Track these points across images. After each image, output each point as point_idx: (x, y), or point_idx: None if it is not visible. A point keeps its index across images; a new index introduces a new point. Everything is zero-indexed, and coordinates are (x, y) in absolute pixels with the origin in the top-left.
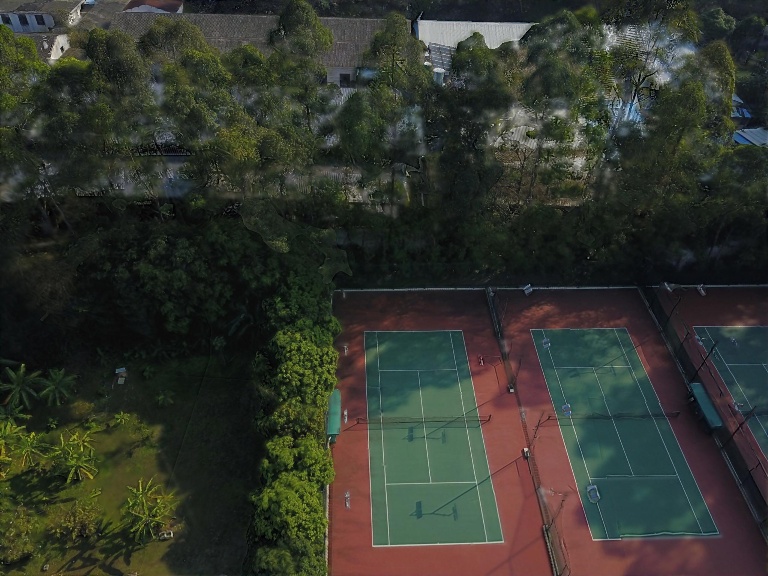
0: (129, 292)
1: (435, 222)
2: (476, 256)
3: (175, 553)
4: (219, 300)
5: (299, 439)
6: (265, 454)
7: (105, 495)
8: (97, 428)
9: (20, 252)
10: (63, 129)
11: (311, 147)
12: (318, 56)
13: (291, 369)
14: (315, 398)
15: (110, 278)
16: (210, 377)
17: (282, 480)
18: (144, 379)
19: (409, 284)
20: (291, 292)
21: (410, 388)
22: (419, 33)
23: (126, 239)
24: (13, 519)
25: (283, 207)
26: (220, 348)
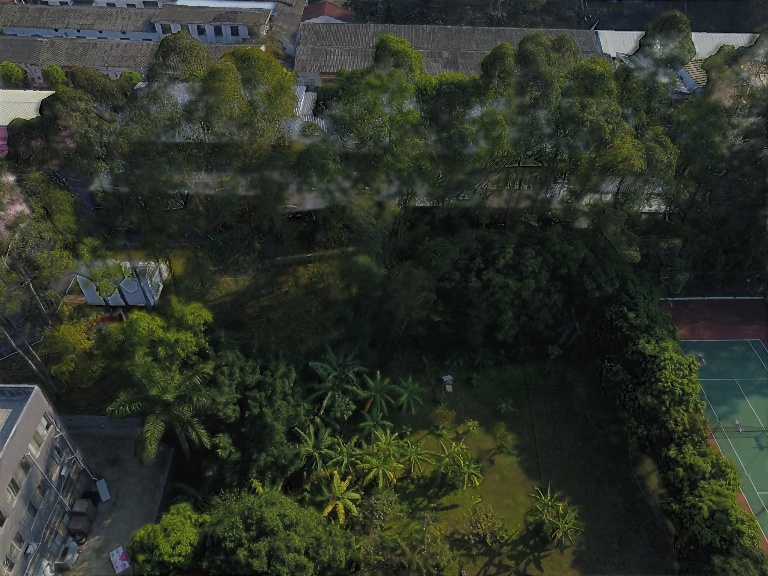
0: (482, 301)
1: (728, 232)
2: (765, 266)
3: (582, 560)
4: (551, 309)
5: (698, 448)
6: (624, 462)
7: (487, 502)
8: (448, 435)
9: (382, 261)
10: (464, 141)
11: (676, 159)
12: (679, 69)
13: (670, 378)
14: (697, 407)
15: (458, 287)
16: (534, 385)
17: (706, 489)
18: (472, 387)
19: (685, 293)
20: (637, 301)
21: (736, 397)
22: (601, 43)
23: (469, 249)
24: (425, 525)
25: (597, 217)
26: (556, 356)
